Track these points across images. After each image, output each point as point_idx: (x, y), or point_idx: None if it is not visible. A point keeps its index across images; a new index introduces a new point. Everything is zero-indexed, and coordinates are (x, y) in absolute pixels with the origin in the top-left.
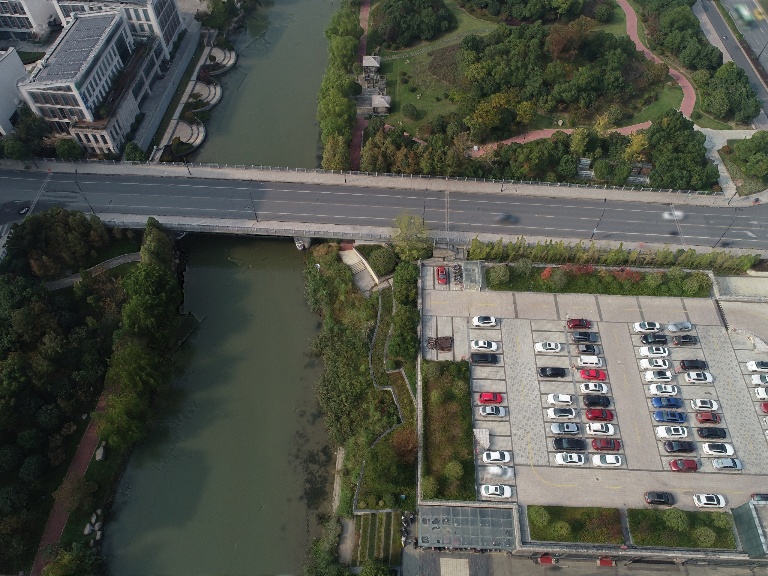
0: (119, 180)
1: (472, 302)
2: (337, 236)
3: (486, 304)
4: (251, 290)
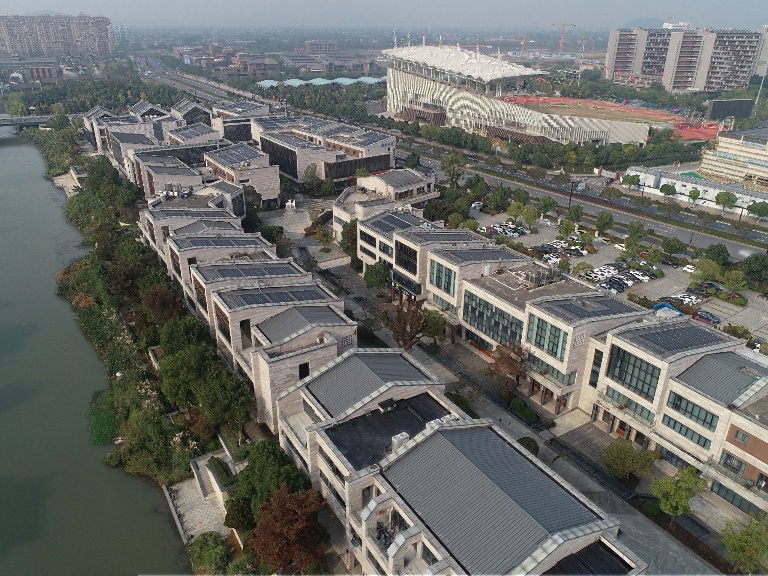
0: None
1: None
2: (30, 121)
3: None
4: None
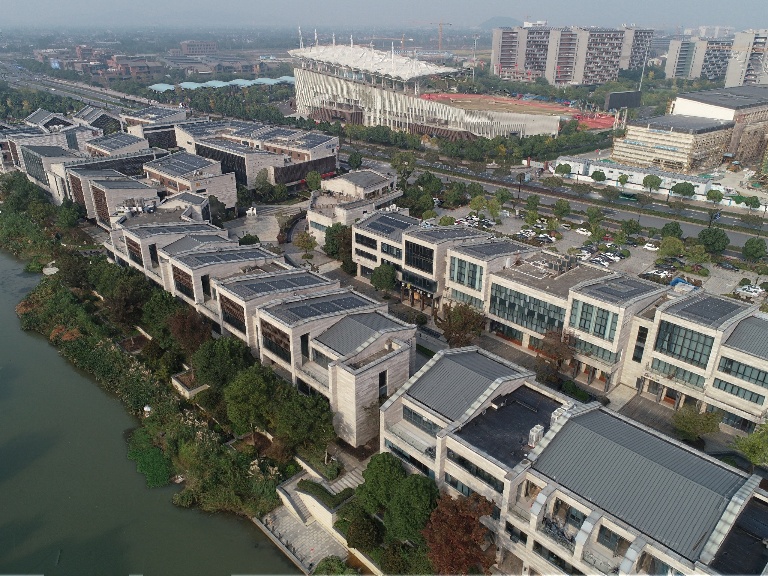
0: None
1: None
2: None
3: None
4: None
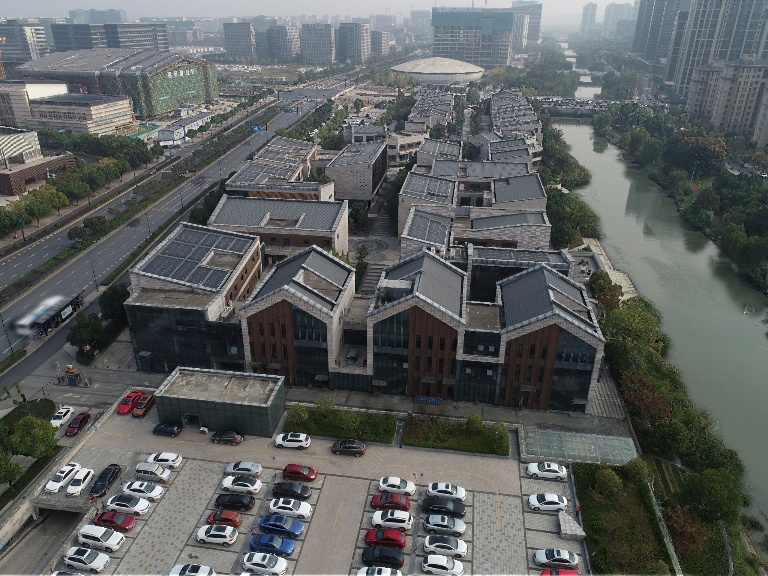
0: None
1: None
2: None
3: None
4: None
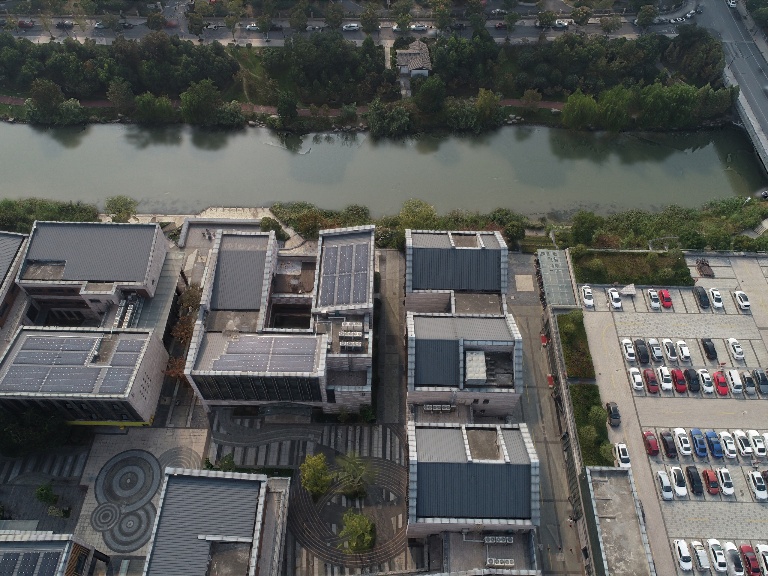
0: (767, 74)
1: (760, 294)
2: None
3: (763, 305)
4: (706, 170)
